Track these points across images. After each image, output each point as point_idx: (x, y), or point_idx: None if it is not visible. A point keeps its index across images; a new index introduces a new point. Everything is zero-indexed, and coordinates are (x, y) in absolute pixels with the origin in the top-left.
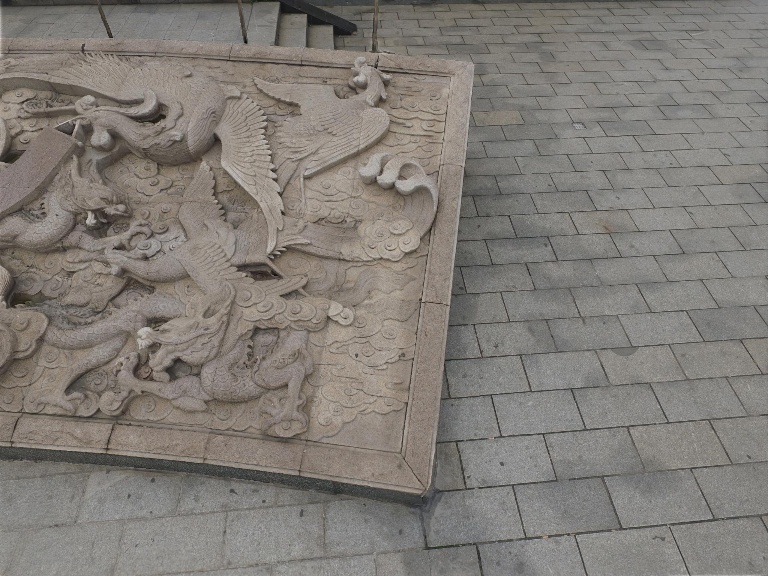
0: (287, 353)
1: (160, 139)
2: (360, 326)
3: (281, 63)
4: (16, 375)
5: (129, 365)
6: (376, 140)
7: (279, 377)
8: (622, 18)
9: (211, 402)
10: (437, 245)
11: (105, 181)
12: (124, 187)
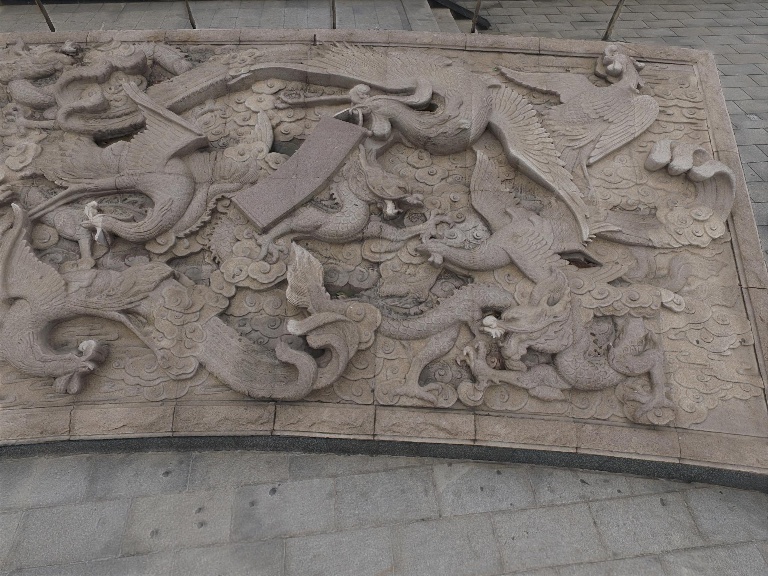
0: (635, 340)
1: (447, 127)
2: (691, 312)
3: (518, 53)
4: (358, 367)
5: (483, 354)
6: (648, 127)
7: (643, 364)
8: (743, 12)
9: (565, 391)
10: (741, 231)
11: None
12: (402, 177)
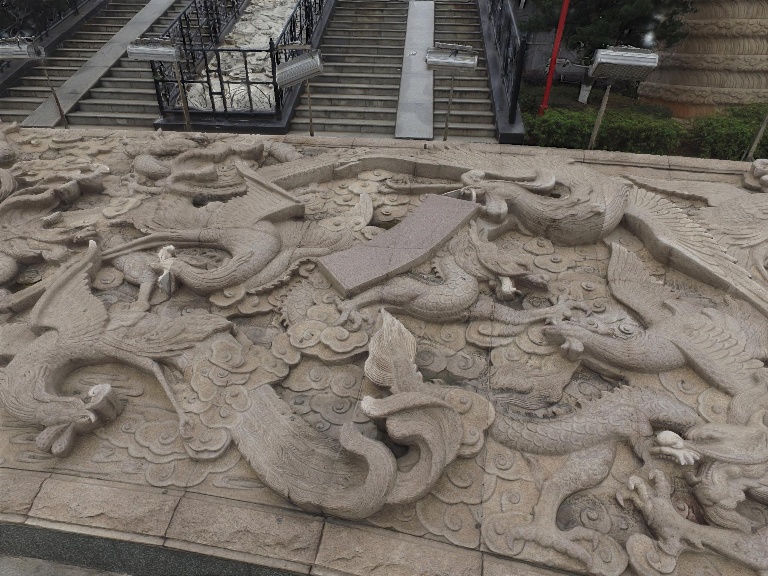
0: None
1: (576, 210)
2: None
3: (645, 167)
4: (456, 483)
5: (665, 490)
6: None
7: None
8: None
9: None
10: None
11: None
12: None
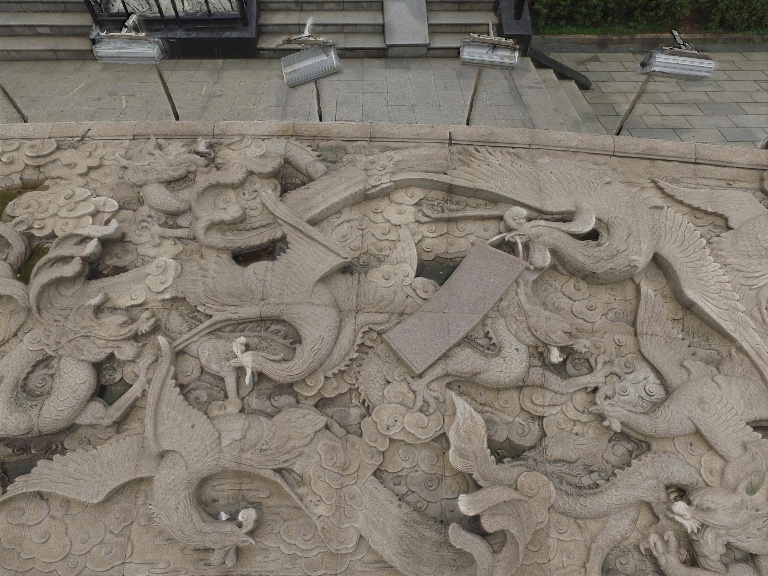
0: None
1: (615, 263)
2: None
3: (672, 160)
4: (531, 549)
5: (675, 549)
6: None
7: None
8: None
9: None
10: None
11: None
12: (557, 310)
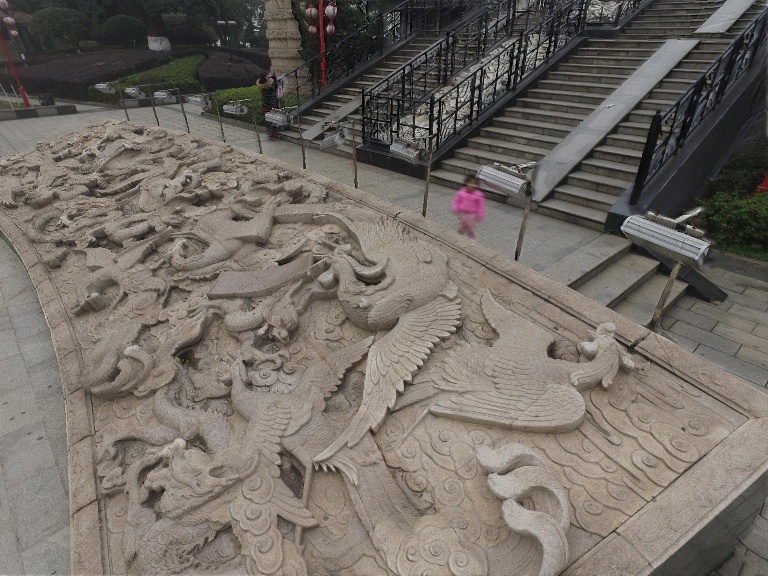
0: None
1: (353, 299)
2: None
3: (528, 289)
4: (124, 404)
5: (146, 460)
6: (545, 428)
7: None
8: None
9: None
10: None
11: (308, 309)
12: (312, 321)
